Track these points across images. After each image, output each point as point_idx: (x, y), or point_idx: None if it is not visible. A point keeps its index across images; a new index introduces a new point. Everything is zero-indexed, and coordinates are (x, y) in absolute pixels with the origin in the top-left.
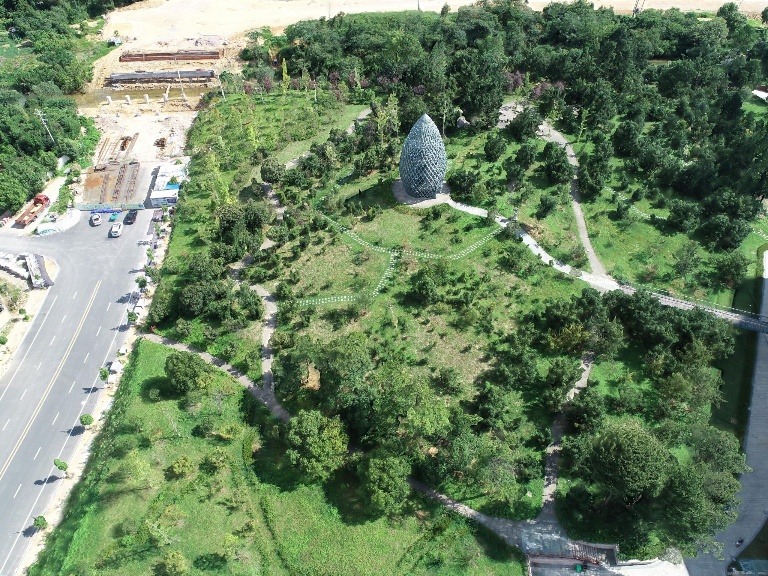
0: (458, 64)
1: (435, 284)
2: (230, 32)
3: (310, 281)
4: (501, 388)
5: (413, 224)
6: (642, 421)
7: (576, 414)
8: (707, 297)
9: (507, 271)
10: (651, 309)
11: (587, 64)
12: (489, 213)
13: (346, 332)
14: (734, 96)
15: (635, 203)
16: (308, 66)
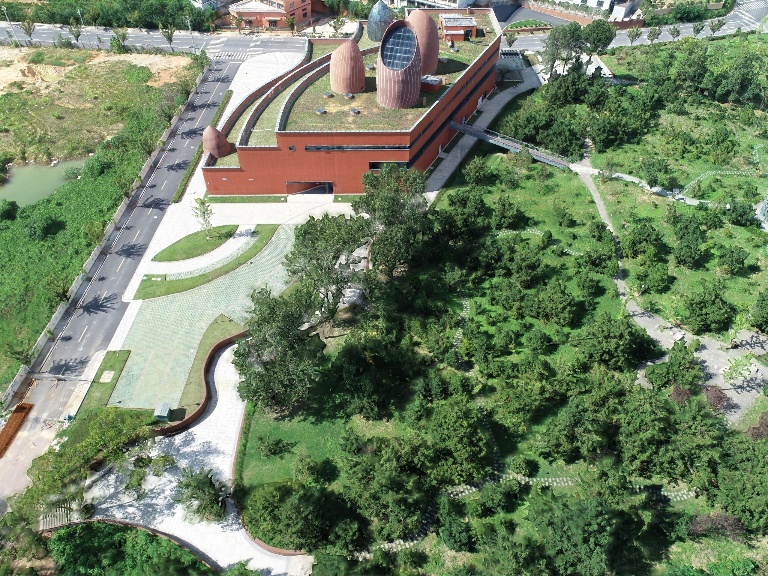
0: None
1: None
2: None
3: None
4: None
5: (764, 193)
6: None
7: None
8: None
9: None
10: None
11: None
12: None
13: None
14: None
15: None
16: None
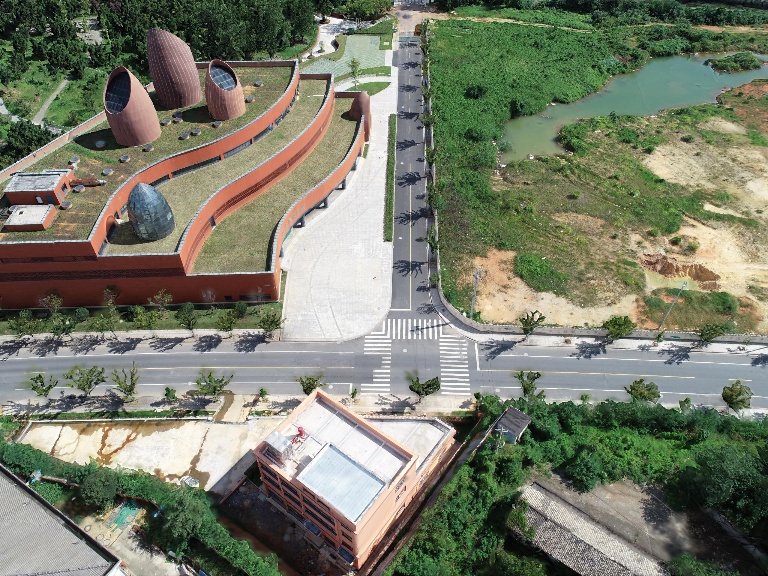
0: None
1: None
2: None
3: None
4: None
5: None
6: None
7: None
8: None
9: None
10: (19, 130)
11: None
12: None
13: None
14: None
15: None
16: None
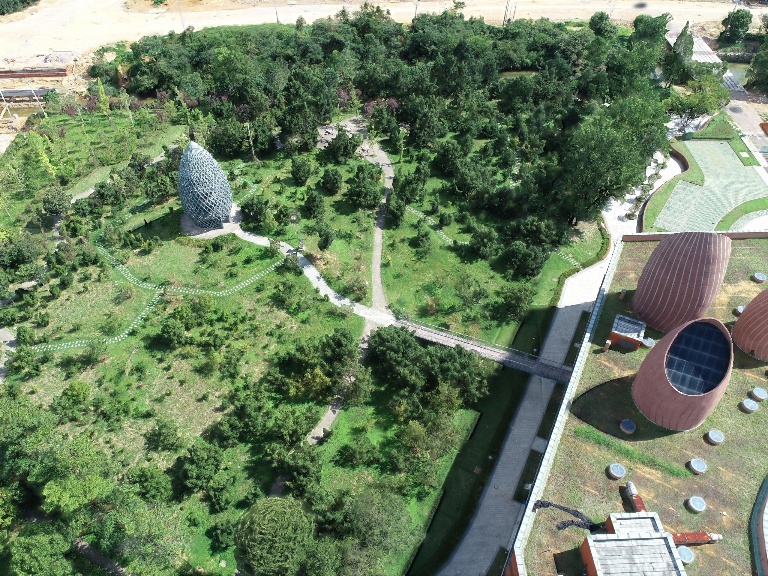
0: (292, 81)
1: (188, 325)
2: (85, 47)
3: (62, 323)
4: (214, 444)
5: (191, 257)
6: (376, 473)
7: (288, 471)
8: (489, 330)
9: (278, 307)
10: (403, 349)
11: (421, 80)
12: (270, 244)
13: (77, 381)
14: (570, 111)
15: (443, 228)
16: (153, 83)
